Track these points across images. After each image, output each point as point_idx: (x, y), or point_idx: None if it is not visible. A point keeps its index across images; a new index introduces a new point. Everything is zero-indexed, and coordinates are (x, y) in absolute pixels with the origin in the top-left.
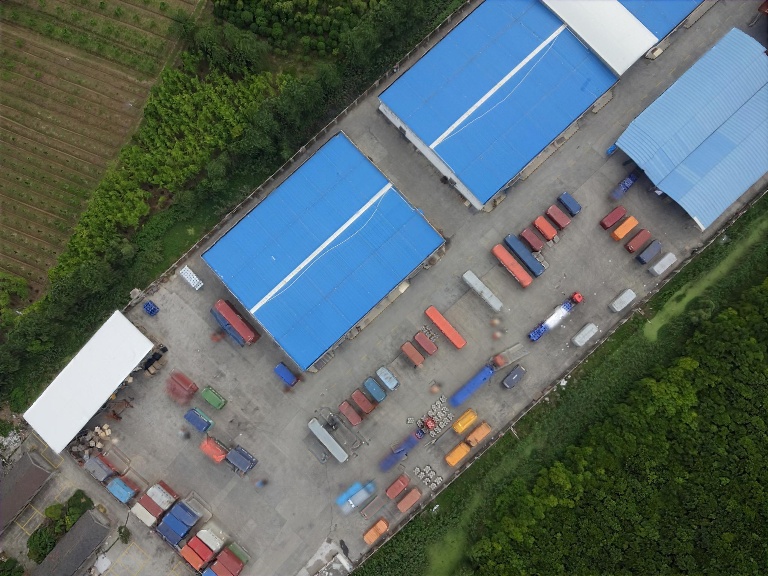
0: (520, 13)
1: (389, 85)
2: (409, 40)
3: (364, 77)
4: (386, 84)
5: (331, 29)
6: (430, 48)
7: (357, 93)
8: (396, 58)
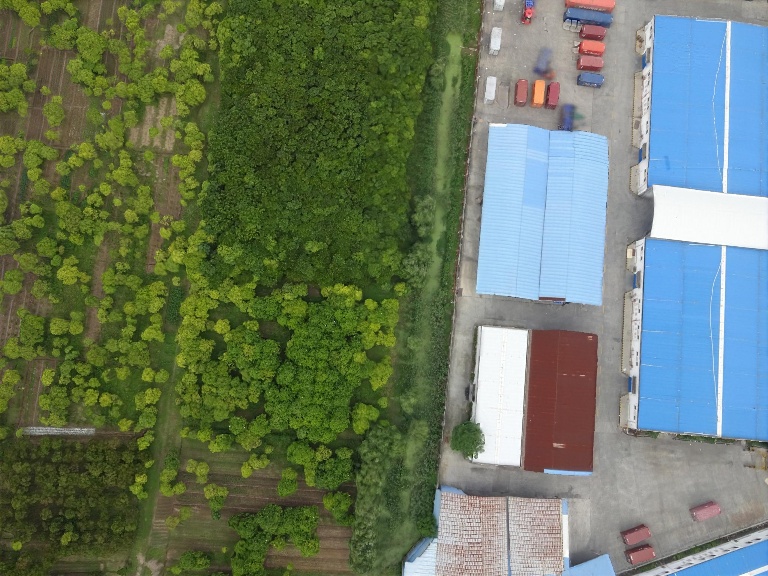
0: (764, 178)
1: None
2: None
3: None
4: None
5: None
6: None
7: None
8: None
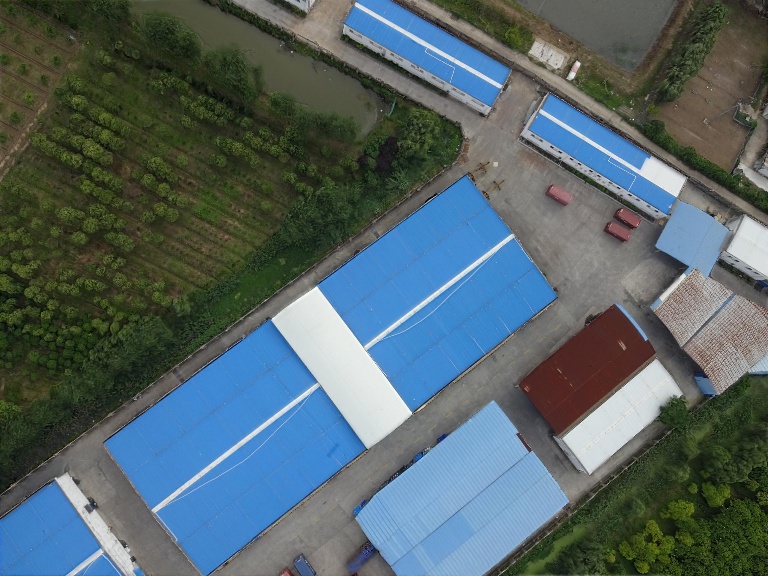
0: (274, 363)
1: (118, 430)
2: (156, 366)
3: (99, 404)
4: (124, 412)
5: (65, 347)
6: (170, 391)
7: (90, 419)
8: (138, 385)
